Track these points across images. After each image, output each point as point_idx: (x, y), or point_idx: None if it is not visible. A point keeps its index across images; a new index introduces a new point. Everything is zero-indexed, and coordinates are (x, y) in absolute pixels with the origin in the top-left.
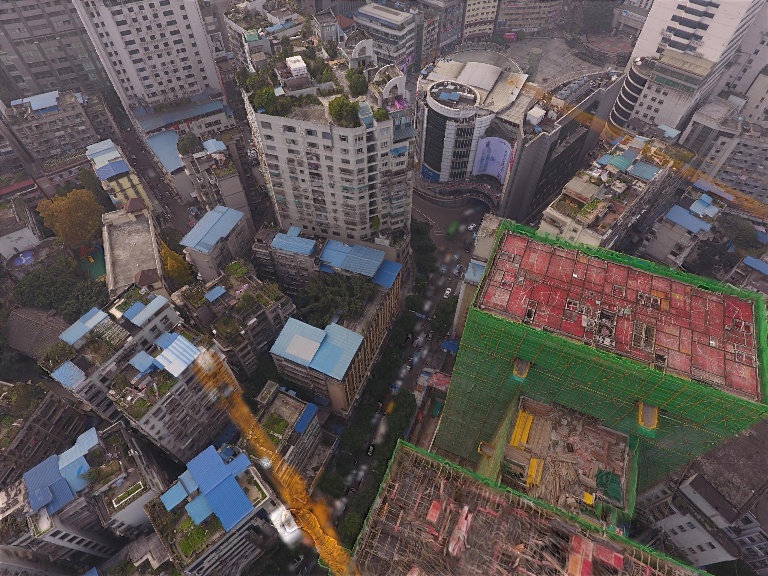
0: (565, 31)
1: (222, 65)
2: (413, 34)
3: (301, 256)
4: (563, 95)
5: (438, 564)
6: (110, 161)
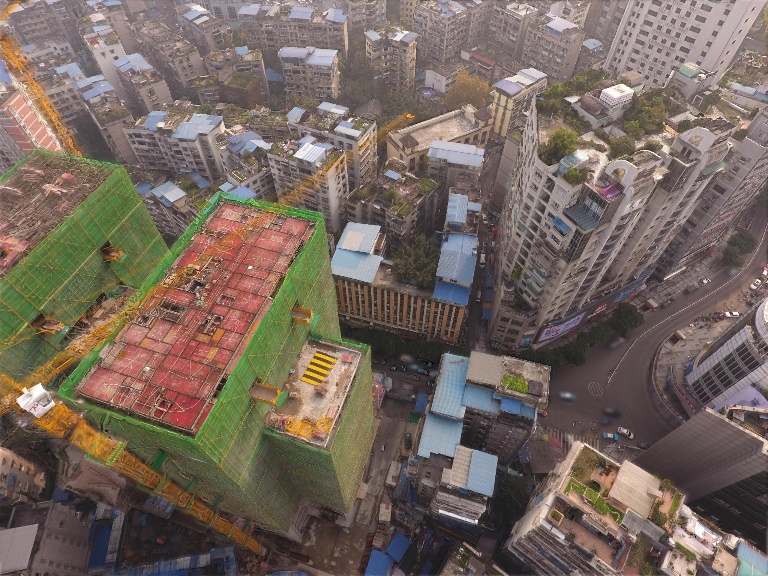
0: None
1: None
2: None
3: None
4: None
5: None
6: (519, 83)
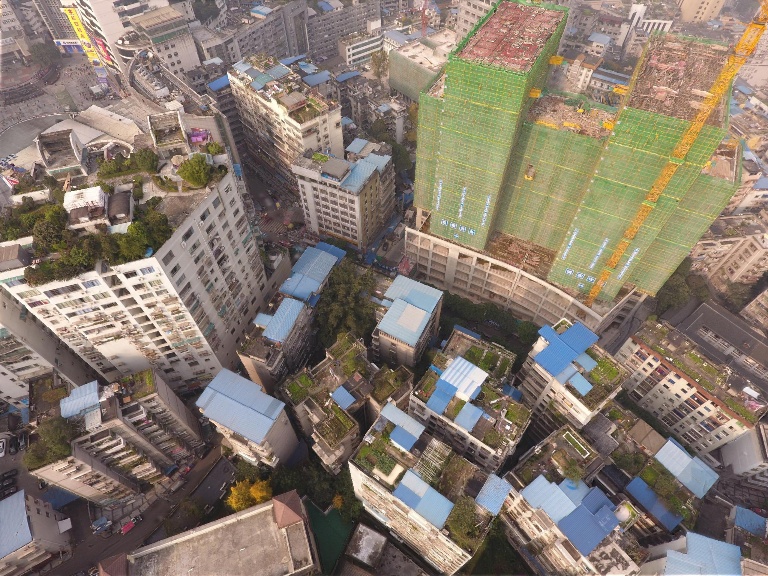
0: None
1: None
2: None
3: (299, 316)
4: (160, 84)
5: (681, 101)
6: None
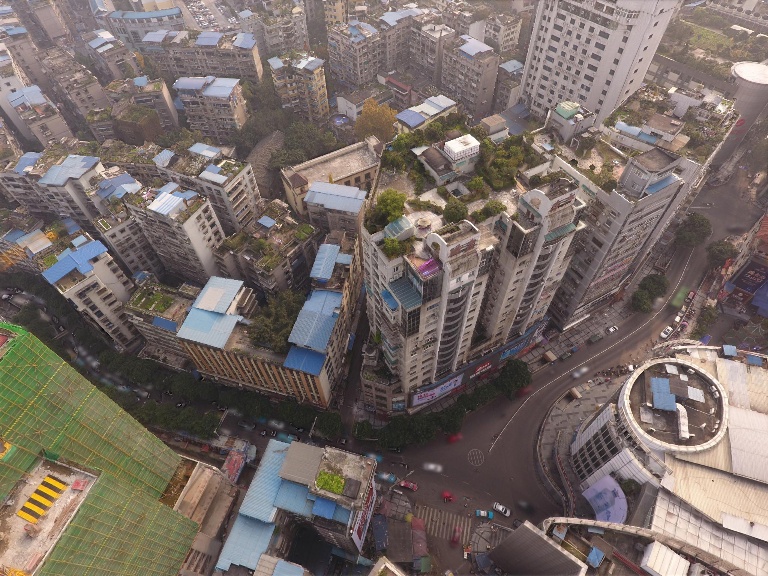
0: None
1: None
2: None
3: None
4: None
5: None
6: (423, 112)
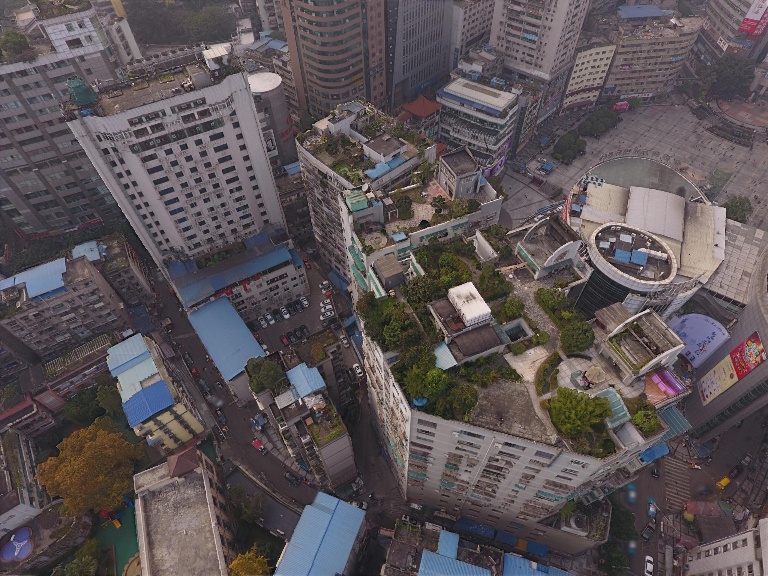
0: (687, 95)
1: (281, 183)
2: (514, 118)
3: None
4: None
5: None
6: (143, 382)
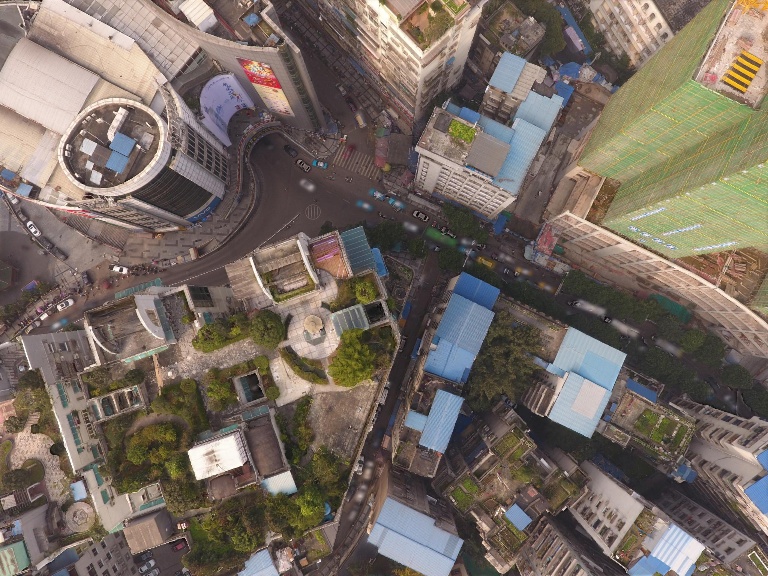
0: None
1: None
2: None
3: None
4: None
5: None
6: None
